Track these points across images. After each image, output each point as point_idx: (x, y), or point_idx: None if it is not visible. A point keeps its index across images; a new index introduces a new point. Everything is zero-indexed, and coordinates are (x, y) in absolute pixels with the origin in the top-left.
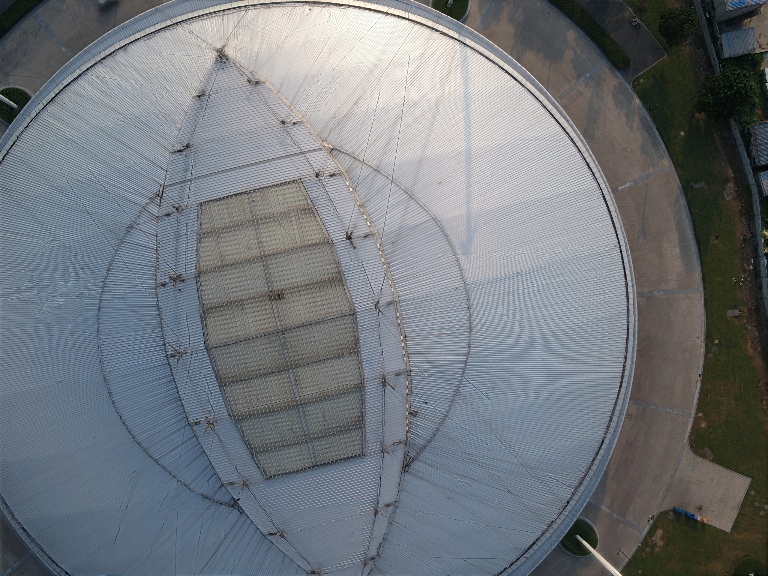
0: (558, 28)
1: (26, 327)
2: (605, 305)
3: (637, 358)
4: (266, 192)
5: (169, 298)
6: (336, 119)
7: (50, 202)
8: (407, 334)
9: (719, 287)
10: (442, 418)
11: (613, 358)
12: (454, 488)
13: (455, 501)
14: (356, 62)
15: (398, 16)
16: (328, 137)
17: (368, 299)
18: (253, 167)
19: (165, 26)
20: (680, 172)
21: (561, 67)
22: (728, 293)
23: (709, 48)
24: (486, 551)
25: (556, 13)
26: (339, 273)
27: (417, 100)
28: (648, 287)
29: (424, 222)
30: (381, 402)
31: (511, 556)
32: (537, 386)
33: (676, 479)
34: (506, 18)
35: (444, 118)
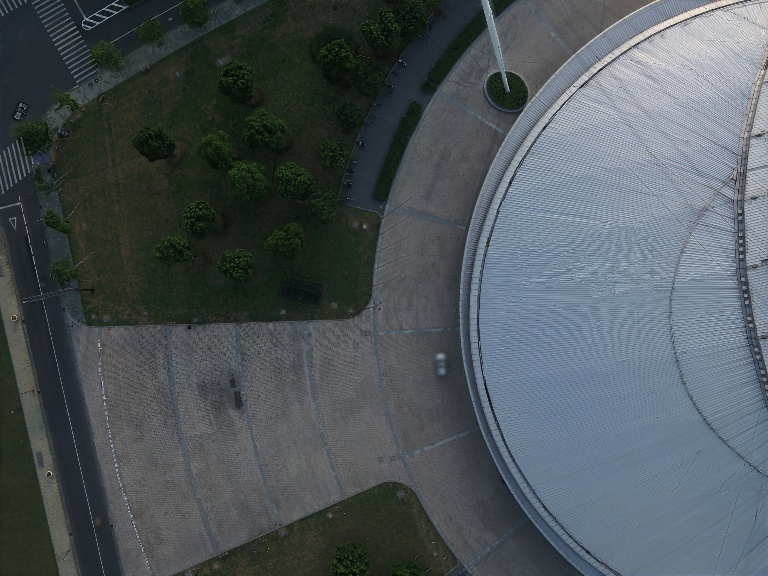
0: None
1: (580, 307)
2: None
3: None
4: None
5: (762, 280)
6: None
7: (606, 184)
8: None
9: None
10: None
11: None
12: None
13: None
14: None
15: None
16: None
17: None
18: None
19: (701, 13)
20: None
21: None
22: None
23: None
24: None
25: None
26: None
27: None
28: None
29: None
30: None
31: None
32: None
33: None
34: None
35: None
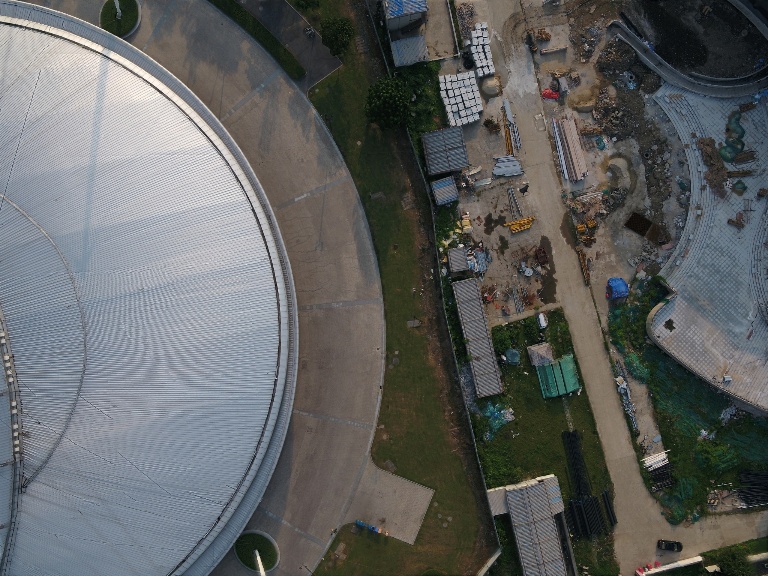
0: (232, 38)
1: None
2: (250, 319)
3: (316, 370)
4: None
5: None
6: None
7: None
8: (15, 354)
9: (398, 298)
10: (57, 438)
11: (261, 373)
12: (79, 508)
13: (82, 521)
14: None
15: (38, 30)
16: None
17: None
18: None
19: None
20: (358, 182)
21: (235, 78)
22: (407, 303)
23: (383, 56)
24: (127, 570)
25: (230, 23)
26: None
27: (41, 116)
28: (326, 299)
29: (35, 240)
30: None
31: (158, 574)
32: (167, 403)
33: (359, 492)
34: (179, 29)
35: (69, 134)
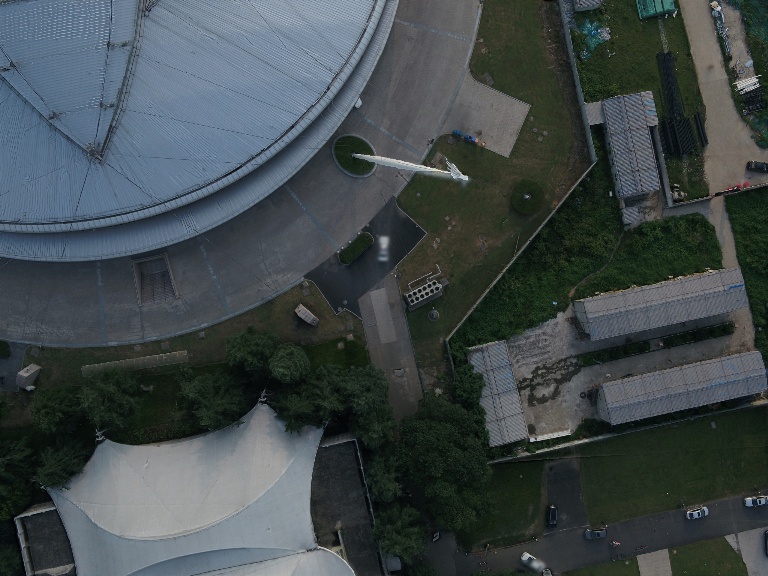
0: None
1: None
2: None
3: None
4: None
5: None
6: None
7: None
8: None
9: None
10: None
11: None
12: (199, 42)
13: (201, 58)
14: None
15: None
16: None
17: None
18: None
19: None
20: None
21: None
22: None
23: None
24: (239, 124)
25: None
26: None
27: None
28: None
29: None
30: None
31: (268, 136)
32: None
33: (456, 104)
34: None
35: None
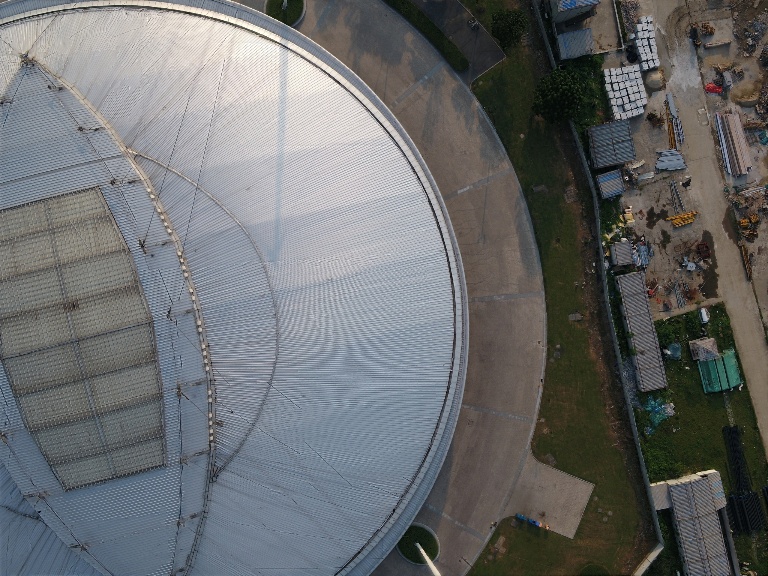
0: (396, 30)
1: None
2: (428, 311)
3: (478, 363)
4: (63, 200)
5: None
6: (142, 125)
7: None
8: (210, 343)
9: (560, 291)
10: (249, 427)
11: (438, 364)
12: (266, 498)
13: (268, 511)
14: (167, 67)
15: (218, 19)
16: (133, 143)
17: (165, 308)
18: (51, 174)
19: None
20: (520, 175)
21: (399, 70)
22: (569, 297)
23: (548, 49)
24: (307, 561)
25: (394, 15)
26: (135, 282)
27: (229, 105)
28: (488, 291)
29: (229, 229)
30: (181, 412)
31: (335, 566)
32: (352, 394)
33: (518, 485)
34: (343, 20)
35: (256, 123)
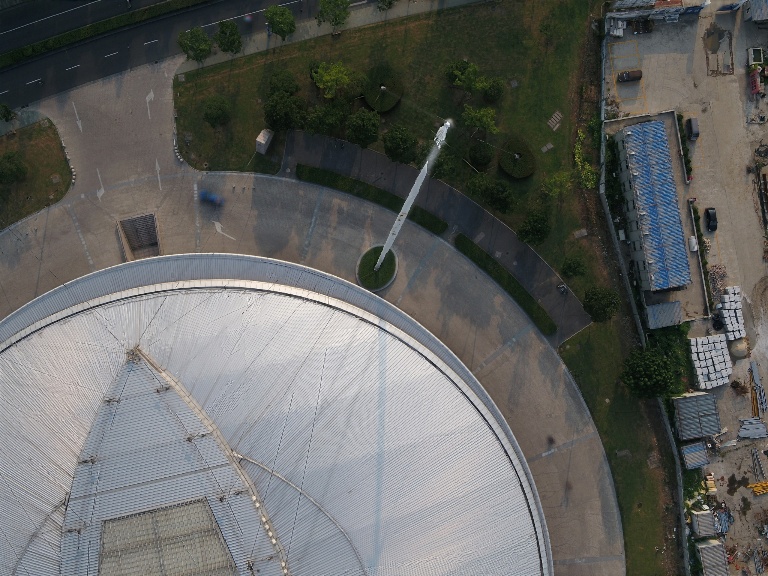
0: (485, 292)
1: None
2: None
3: None
4: (170, 512)
5: None
6: (247, 425)
7: None
8: None
9: (641, 556)
10: None
11: None
12: None
13: None
14: (271, 360)
15: (318, 302)
16: (238, 445)
17: None
18: (159, 483)
19: (82, 310)
20: (604, 439)
21: (487, 332)
22: (650, 562)
23: (636, 317)
24: None
25: (484, 277)
26: None
27: (331, 401)
28: (570, 554)
29: (332, 536)
30: None
31: None
32: None
33: None
34: (433, 281)
35: (358, 419)
